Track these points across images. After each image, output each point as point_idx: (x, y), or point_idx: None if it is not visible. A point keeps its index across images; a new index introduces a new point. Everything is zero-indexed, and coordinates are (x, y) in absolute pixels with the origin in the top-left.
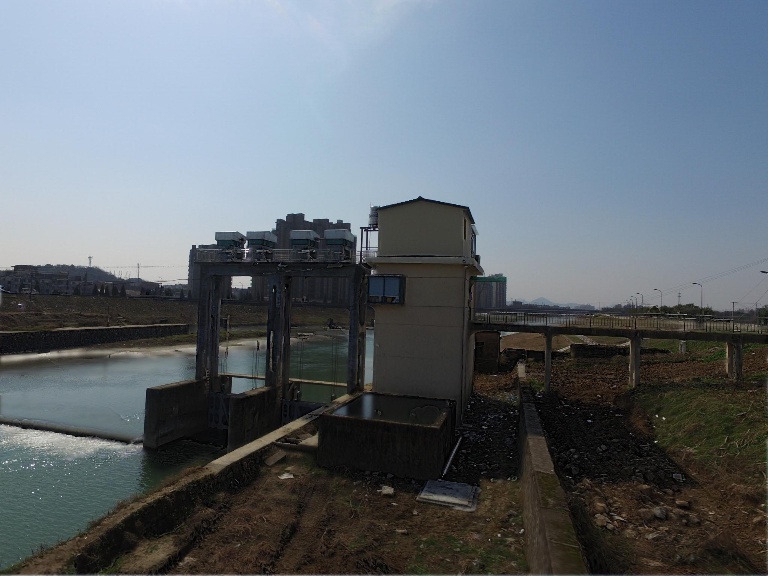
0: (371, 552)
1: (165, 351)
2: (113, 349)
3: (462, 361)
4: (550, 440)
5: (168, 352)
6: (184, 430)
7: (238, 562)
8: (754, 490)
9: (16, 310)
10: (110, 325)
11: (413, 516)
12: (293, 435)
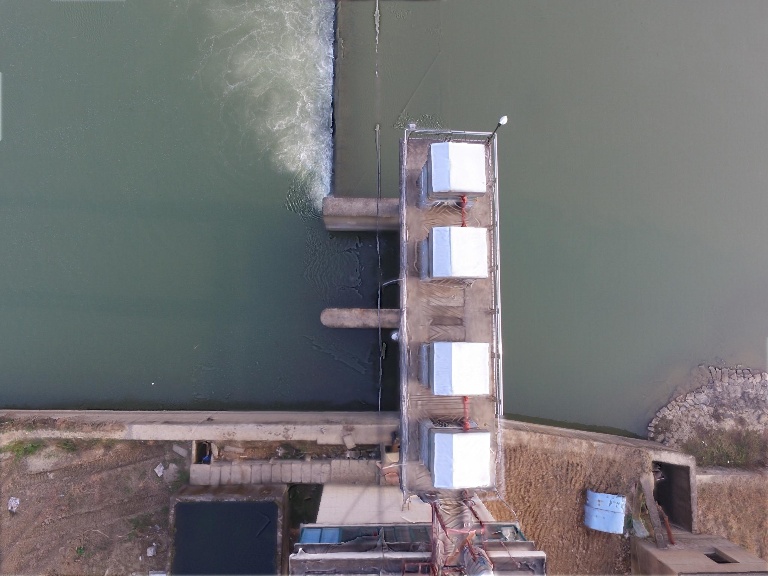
0: (60, 571)
1: None
2: None
3: None
4: None
5: None
6: (367, 229)
7: (50, 504)
8: None
9: None
10: None
11: (131, 573)
12: (223, 443)
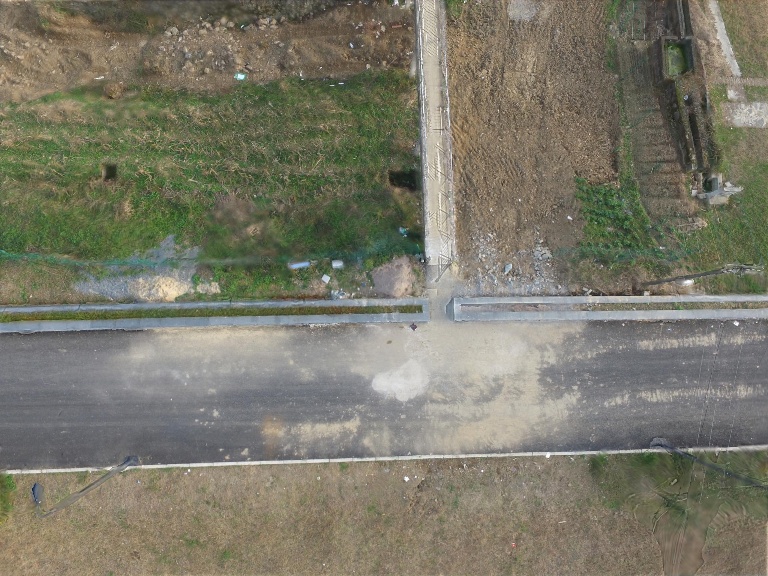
0: None
1: None
2: None
3: None
4: (235, 1)
5: None
6: None
7: None
8: (189, 87)
9: None
10: None
11: None
12: None
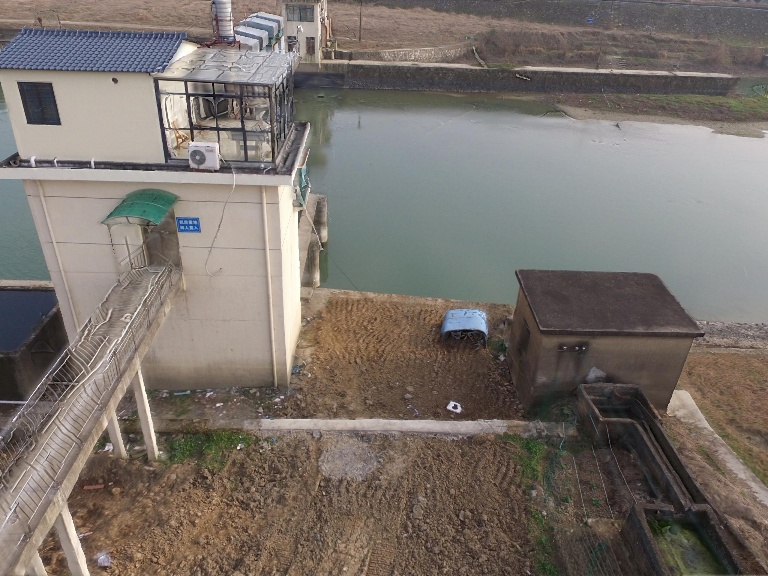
0: None
1: (604, 122)
2: (557, 105)
3: (74, 318)
4: None
5: (604, 125)
6: None
7: None
8: None
9: (586, 25)
10: (600, 67)
11: None
12: None
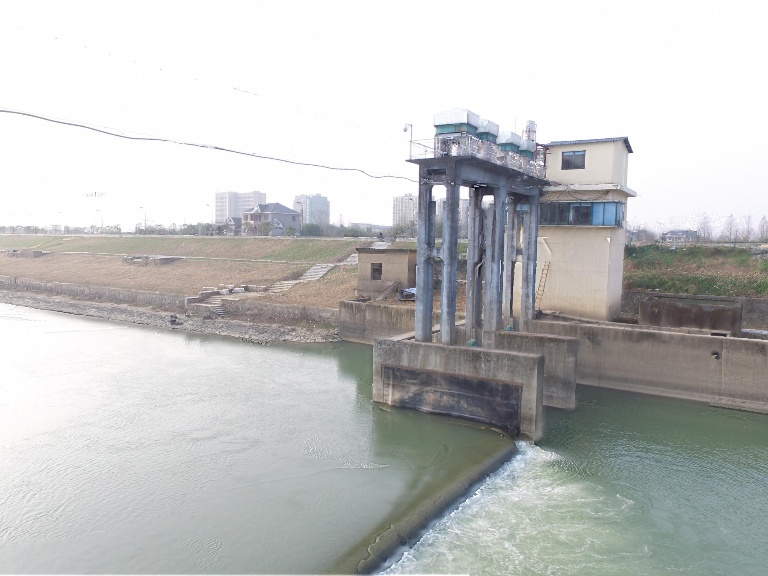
0: None
1: None
2: None
3: None
4: None
5: None
6: None
7: None
8: None
9: None
10: None
11: None
12: None
